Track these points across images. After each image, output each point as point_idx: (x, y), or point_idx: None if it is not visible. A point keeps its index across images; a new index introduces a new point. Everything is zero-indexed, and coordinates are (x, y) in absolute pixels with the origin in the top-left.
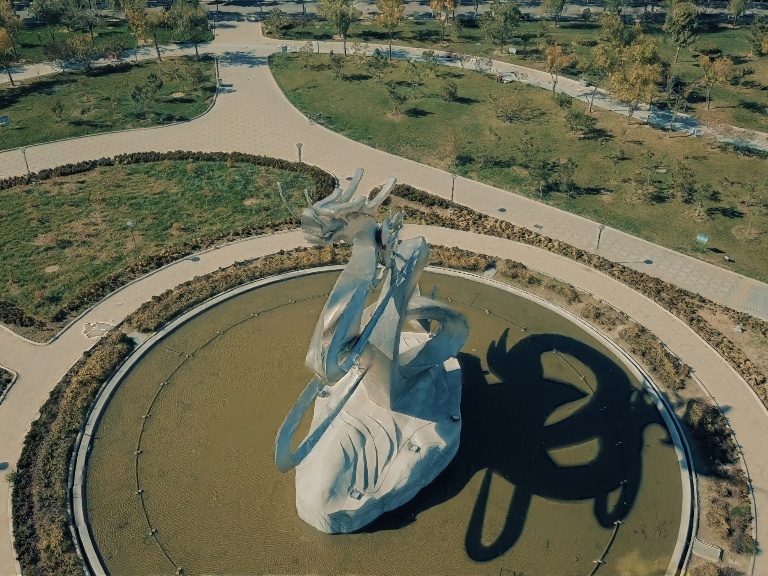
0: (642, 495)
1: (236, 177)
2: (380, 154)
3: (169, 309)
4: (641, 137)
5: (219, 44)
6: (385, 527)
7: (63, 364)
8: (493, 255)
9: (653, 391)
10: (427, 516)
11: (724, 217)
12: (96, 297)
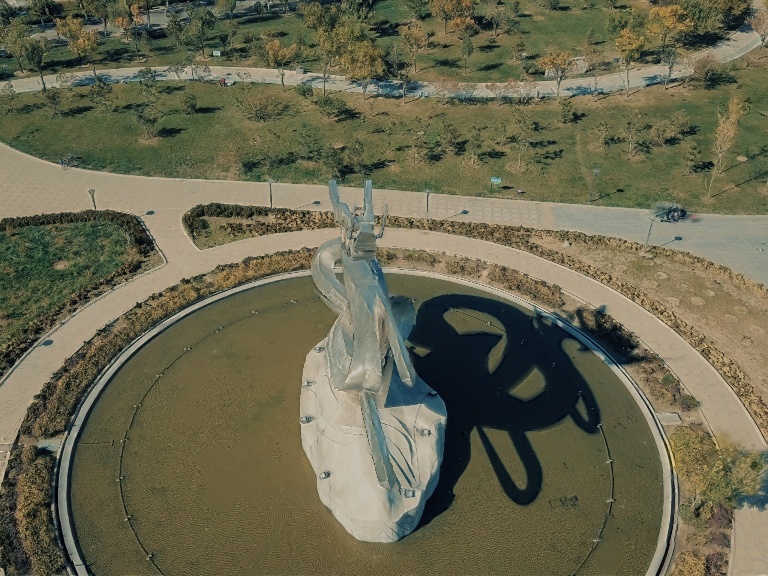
0: (599, 397)
1: (27, 244)
2: (162, 181)
3: (65, 402)
4: (383, 108)
5: None
6: (436, 513)
7: None
8: None
9: (547, 314)
10: (461, 488)
11: (493, 159)
12: None
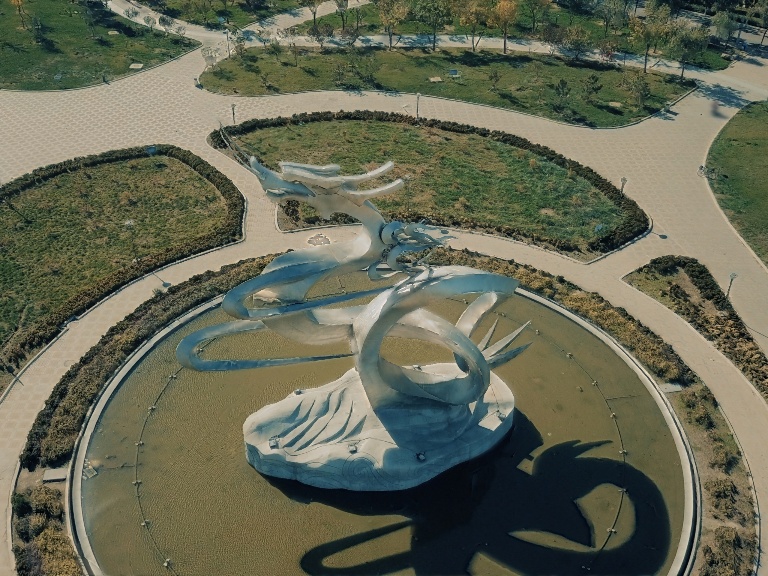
0: None
1: (561, 187)
2: (728, 230)
3: None
4: None
5: (721, 75)
6: (284, 489)
7: (273, 249)
8: (700, 375)
9: None
10: (319, 508)
11: None
12: (347, 220)
